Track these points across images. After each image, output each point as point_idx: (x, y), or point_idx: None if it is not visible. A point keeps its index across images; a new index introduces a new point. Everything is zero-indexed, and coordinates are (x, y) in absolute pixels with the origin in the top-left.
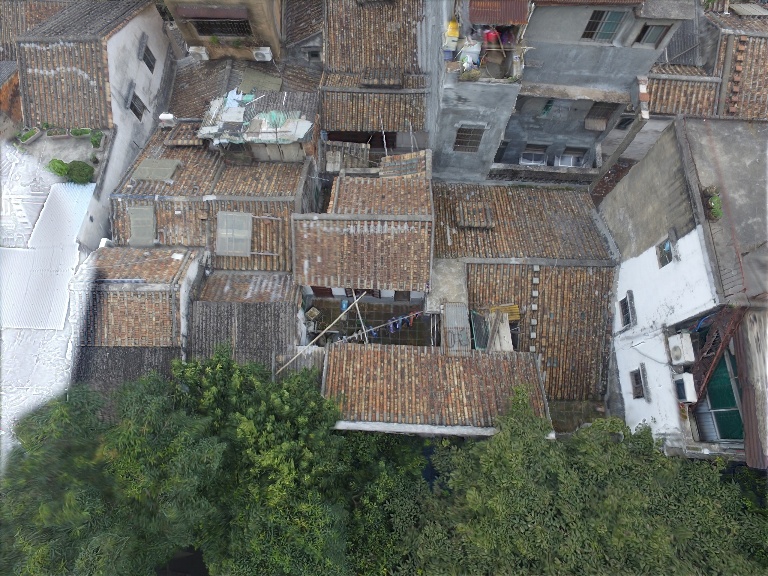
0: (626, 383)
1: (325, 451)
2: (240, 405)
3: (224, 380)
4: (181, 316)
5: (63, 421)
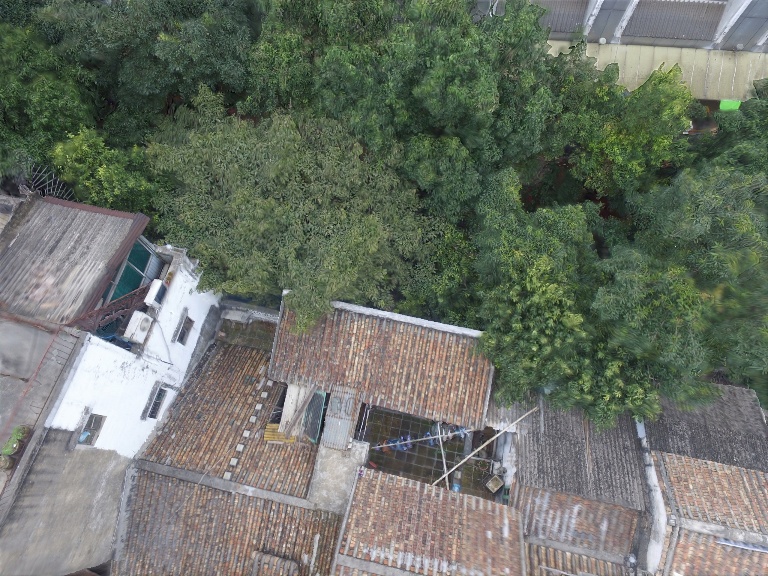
0: (193, 339)
1: (495, 305)
2: (579, 358)
3: (599, 388)
4: (658, 487)
5: (765, 327)
